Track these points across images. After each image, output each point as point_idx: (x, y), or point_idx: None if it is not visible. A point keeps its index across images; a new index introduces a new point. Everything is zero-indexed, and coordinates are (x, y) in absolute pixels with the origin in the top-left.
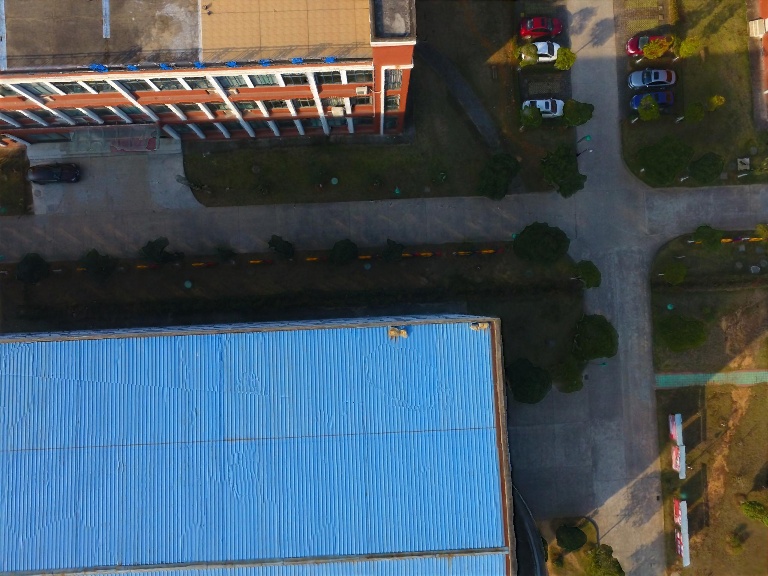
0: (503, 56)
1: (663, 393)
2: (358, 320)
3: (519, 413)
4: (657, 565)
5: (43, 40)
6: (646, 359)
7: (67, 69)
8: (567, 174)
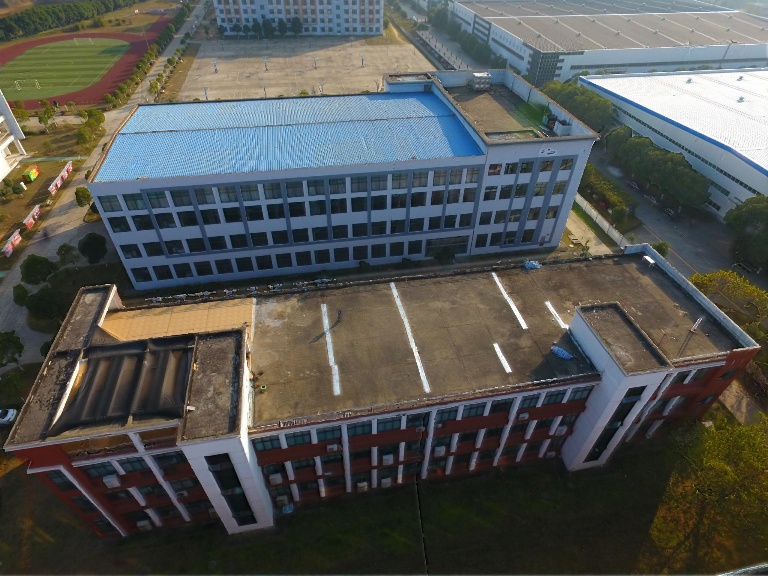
0: (10, 465)
1: (5, 269)
2: (182, 229)
3: (109, 252)
4: (56, 211)
5: (368, 299)
6: (6, 283)
7: (349, 287)
8: (3, 335)
